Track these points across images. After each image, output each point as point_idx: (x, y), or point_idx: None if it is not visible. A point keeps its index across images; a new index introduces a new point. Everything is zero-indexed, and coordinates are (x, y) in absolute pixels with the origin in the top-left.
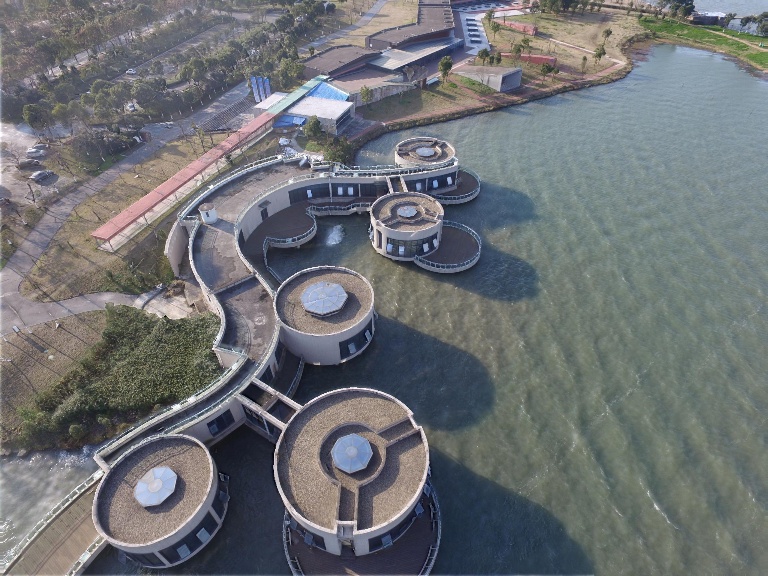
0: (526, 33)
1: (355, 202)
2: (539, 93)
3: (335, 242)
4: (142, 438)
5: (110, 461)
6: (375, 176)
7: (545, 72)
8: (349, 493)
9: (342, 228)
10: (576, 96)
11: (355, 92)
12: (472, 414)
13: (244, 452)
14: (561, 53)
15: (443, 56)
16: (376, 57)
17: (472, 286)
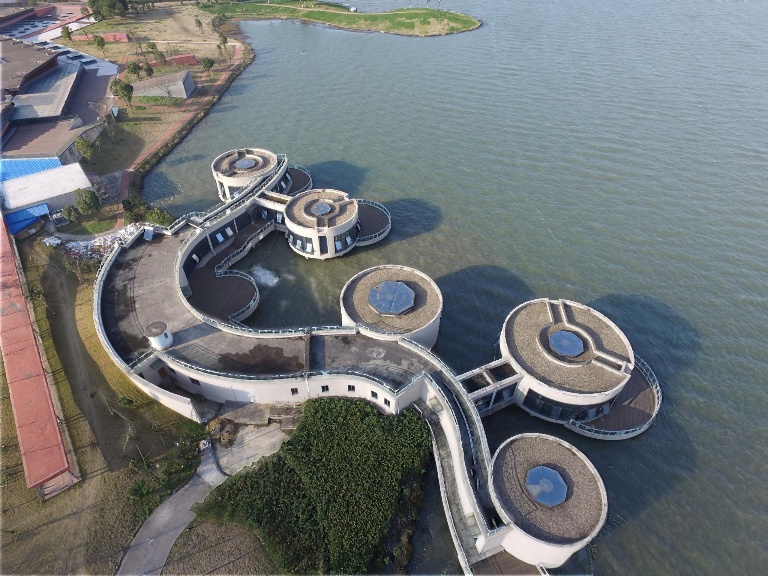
0: (120, 42)
1: (241, 239)
2: (219, 87)
3: (275, 280)
4: (476, 492)
5: (493, 528)
6: (244, 203)
7: (208, 67)
8: (597, 359)
9: (259, 267)
10: (246, 80)
11: (61, 152)
12: (526, 291)
13: (502, 431)
14: (184, 50)
15: (80, 86)
16: (11, 110)
17: (409, 232)
